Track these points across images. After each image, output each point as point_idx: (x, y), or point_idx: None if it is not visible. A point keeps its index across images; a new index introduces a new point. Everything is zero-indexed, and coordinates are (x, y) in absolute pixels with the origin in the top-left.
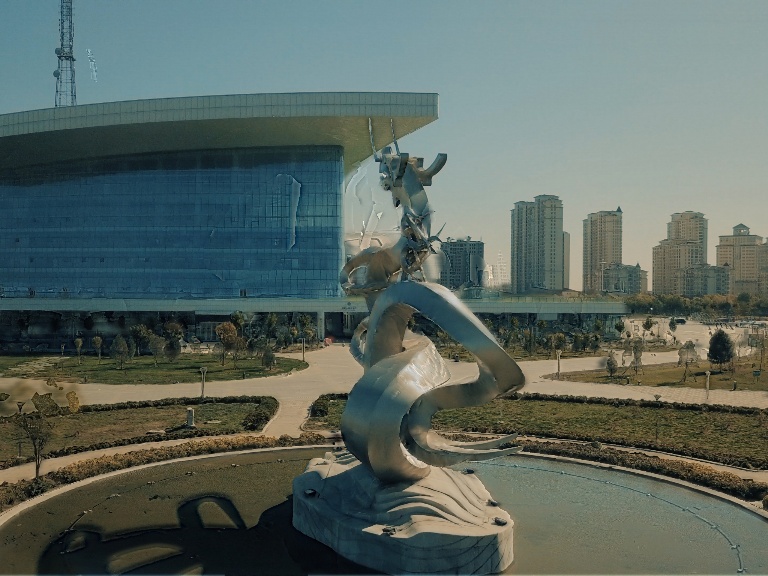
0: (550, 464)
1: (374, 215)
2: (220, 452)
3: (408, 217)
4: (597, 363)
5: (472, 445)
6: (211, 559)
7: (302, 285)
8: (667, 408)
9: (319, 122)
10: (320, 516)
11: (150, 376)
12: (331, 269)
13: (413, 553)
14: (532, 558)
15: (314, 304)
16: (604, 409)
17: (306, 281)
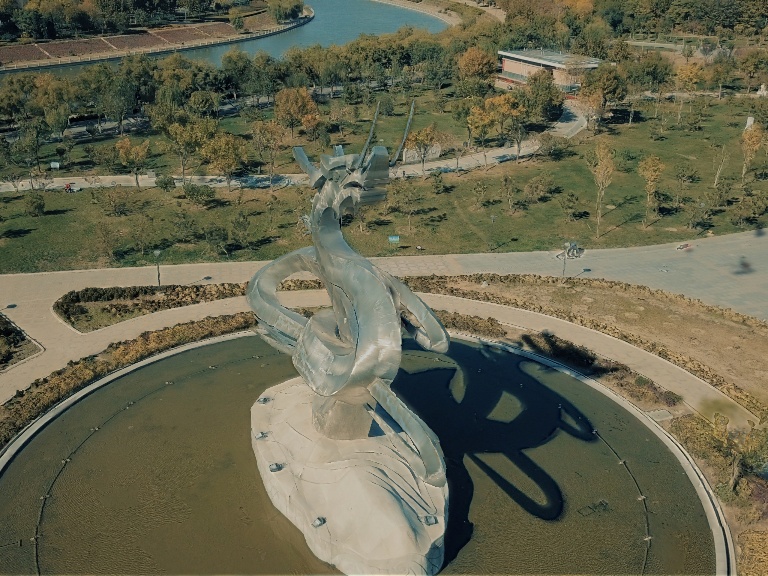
0: None
1: None
2: None
3: None
4: None
5: None
6: None
7: None
8: None
9: None
10: None
11: None
12: None
13: None
14: None
15: None
16: None
17: None
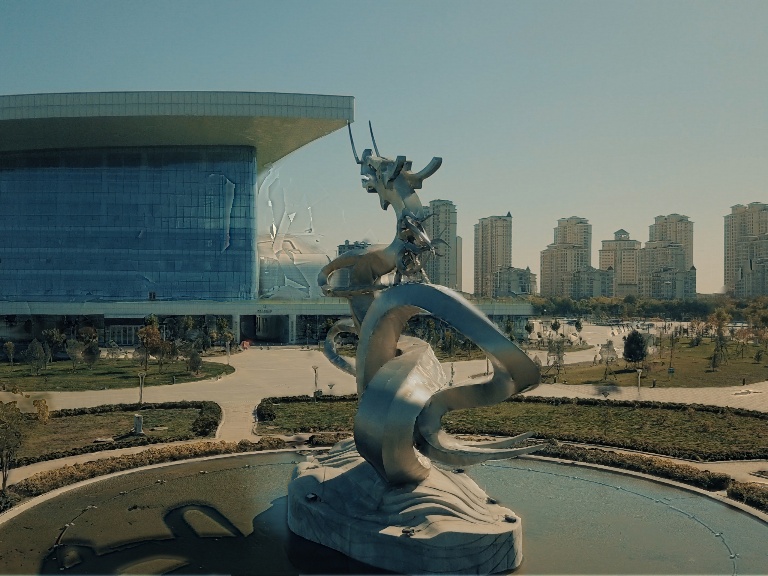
0: (514, 462)
1: (286, 217)
2: (183, 459)
3: (407, 219)
4: None
5: (486, 444)
6: (216, 569)
7: (214, 287)
8: (601, 405)
9: (233, 122)
10: (326, 520)
11: (73, 382)
12: (244, 271)
13: (435, 553)
14: (534, 553)
15: (229, 307)
16: (543, 407)
17: (218, 283)
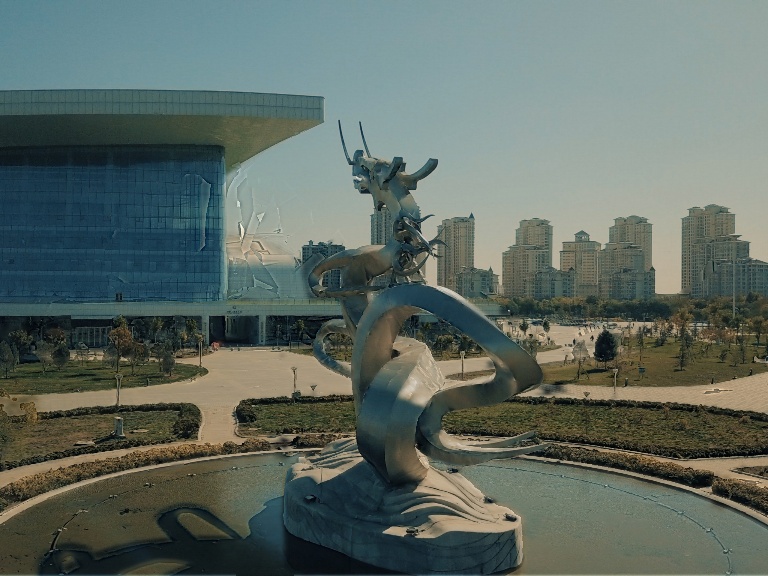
0: (500, 461)
1: (254, 217)
2: (168, 462)
3: (404, 220)
4: (488, 363)
5: (488, 444)
6: (217, 572)
7: (182, 288)
8: (578, 404)
9: (202, 121)
10: (327, 521)
11: (44, 385)
12: (213, 272)
13: (440, 552)
14: (532, 551)
15: (198, 308)
16: (521, 407)
17: (187, 284)
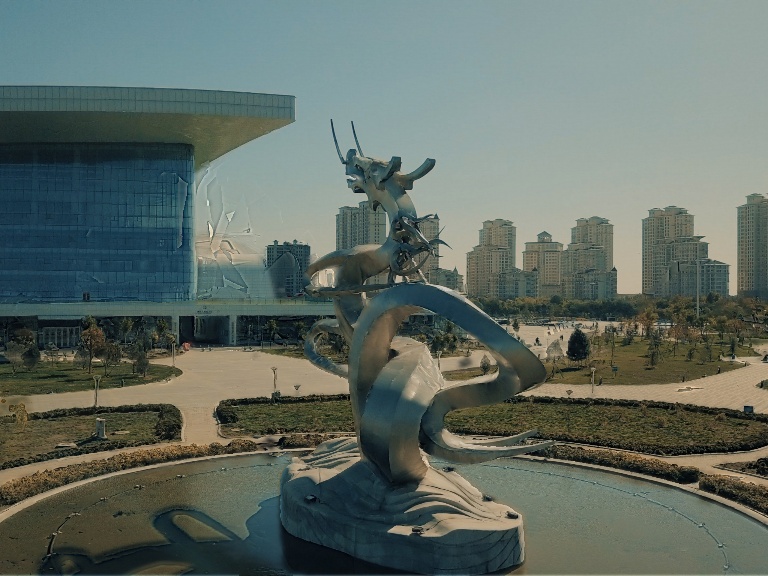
0: None
1: (224, 217)
2: (155, 463)
3: (403, 220)
4: (461, 363)
5: (491, 442)
6: (219, 573)
7: (151, 288)
8: (557, 403)
9: (172, 119)
10: (328, 521)
11: (15, 386)
12: (182, 271)
13: (447, 551)
14: (531, 548)
15: (168, 308)
16: (501, 406)
17: (156, 284)
